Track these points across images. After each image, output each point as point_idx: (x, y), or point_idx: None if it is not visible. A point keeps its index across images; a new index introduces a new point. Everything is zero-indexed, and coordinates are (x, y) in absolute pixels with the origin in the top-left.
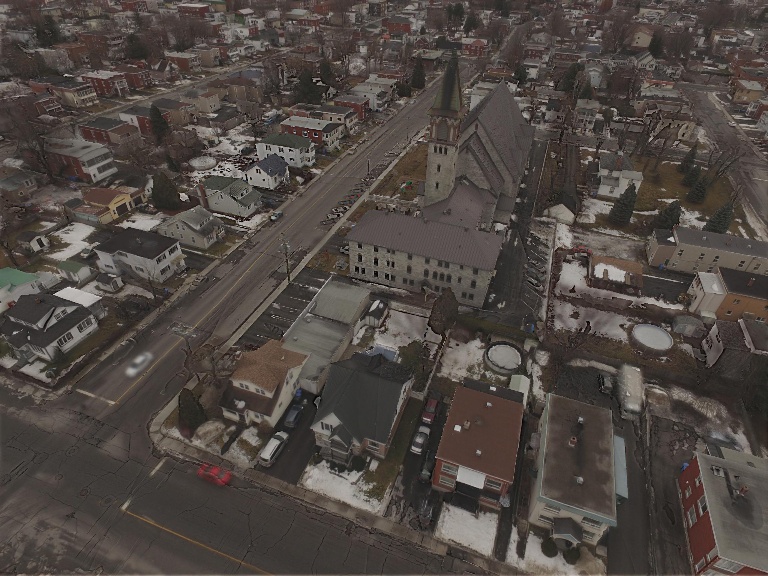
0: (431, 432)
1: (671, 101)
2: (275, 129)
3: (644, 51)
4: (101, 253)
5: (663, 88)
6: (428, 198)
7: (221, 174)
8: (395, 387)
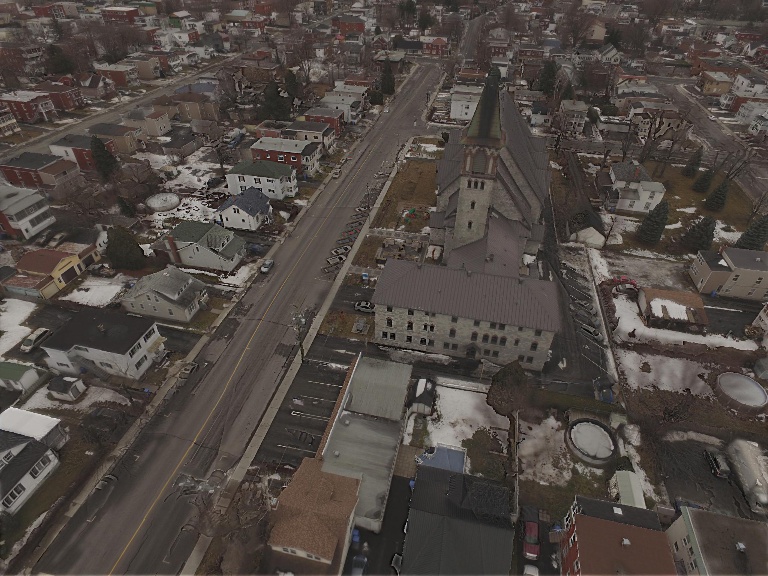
0: (539, 572)
1: (653, 98)
2: (244, 154)
3: (606, 45)
4: (51, 351)
5: (639, 84)
6: (458, 239)
7: (188, 215)
8: (504, 536)
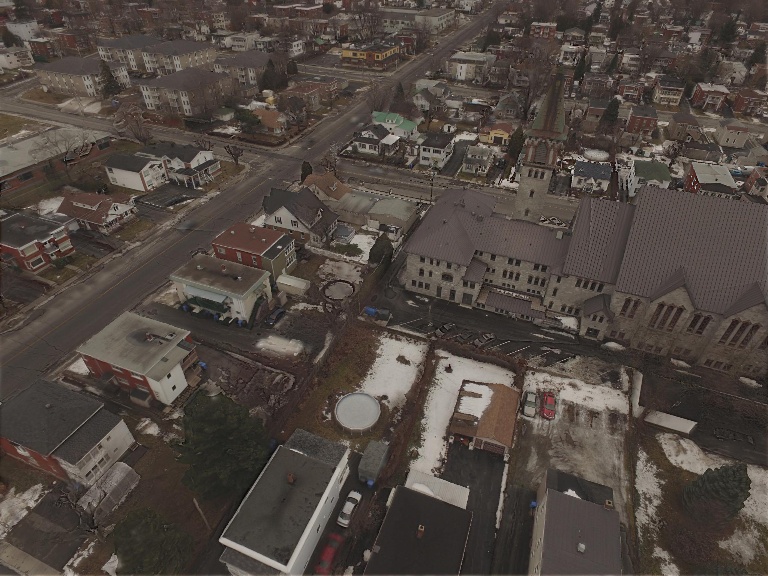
0: None
1: None
2: None
3: None
4: None
5: None
6: None
7: None
8: None
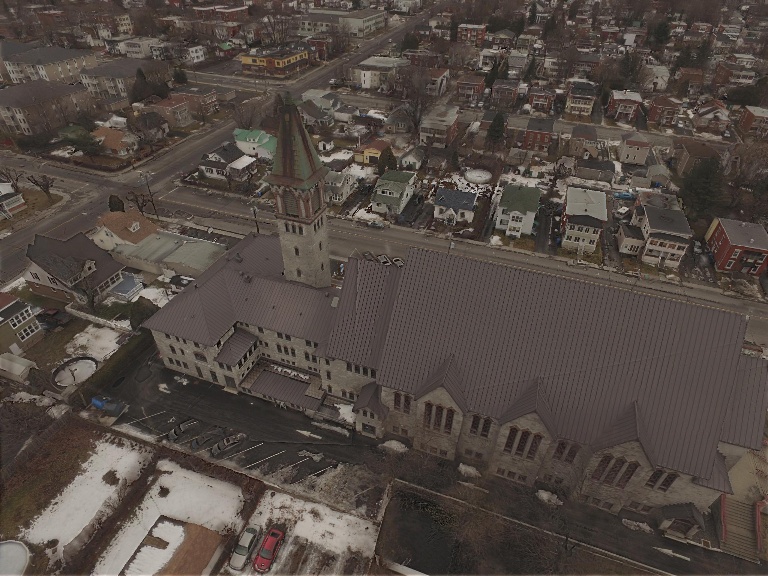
0: None
1: None
2: None
3: None
4: None
5: None
6: None
7: (461, 189)
8: None
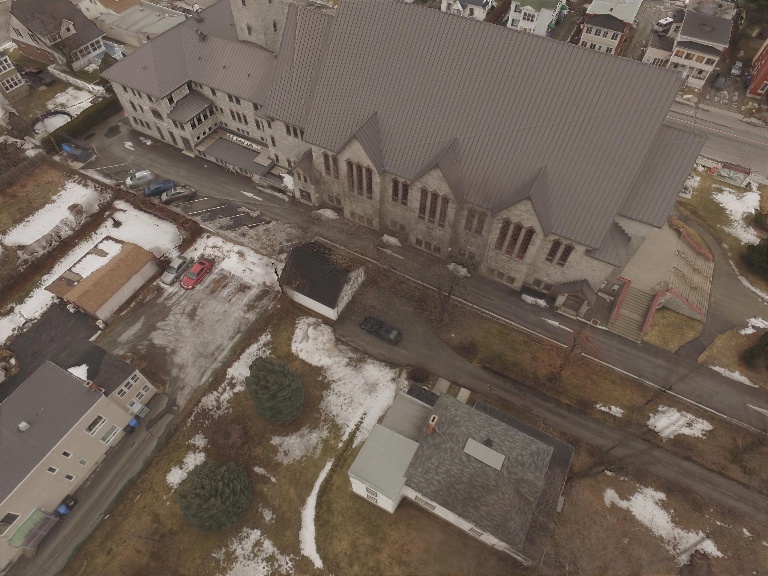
0: (23, 75)
1: None
2: None
3: None
4: None
5: None
6: None
7: None
8: None
